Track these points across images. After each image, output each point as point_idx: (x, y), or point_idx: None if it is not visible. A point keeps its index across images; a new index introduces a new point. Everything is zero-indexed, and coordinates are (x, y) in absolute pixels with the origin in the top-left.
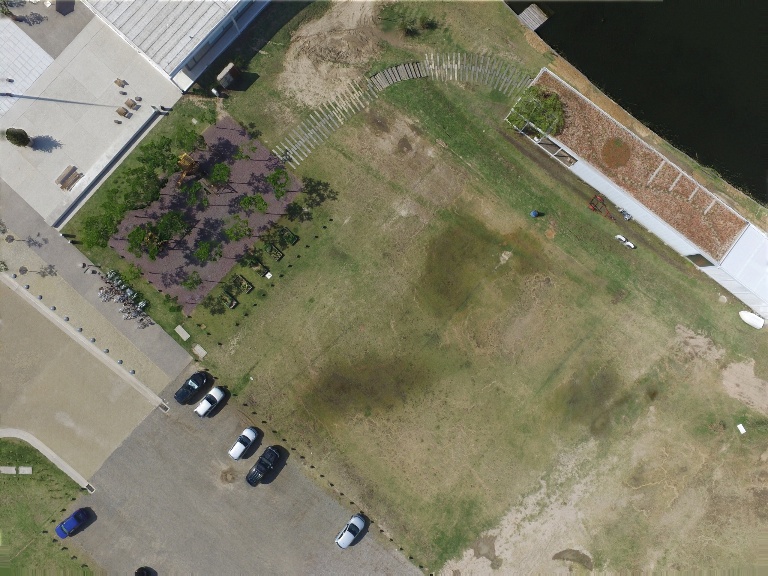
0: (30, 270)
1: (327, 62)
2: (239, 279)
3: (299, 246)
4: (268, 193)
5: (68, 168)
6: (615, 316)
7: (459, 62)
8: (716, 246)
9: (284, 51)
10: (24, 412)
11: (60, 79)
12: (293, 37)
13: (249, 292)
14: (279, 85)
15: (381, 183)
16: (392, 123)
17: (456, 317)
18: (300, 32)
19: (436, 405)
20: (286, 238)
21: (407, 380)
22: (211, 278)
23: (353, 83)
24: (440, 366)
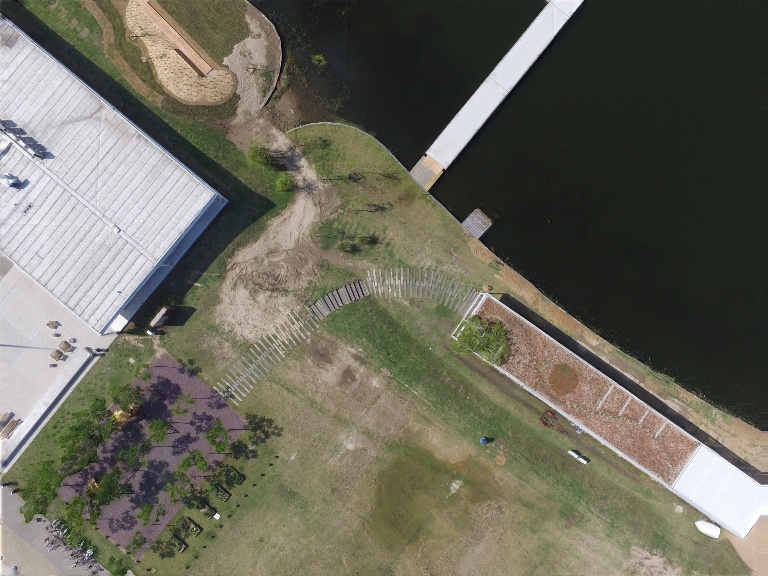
0: None
1: (265, 291)
2: (187, 522)
3: (246, 485)
4: None
5: (5, 416)
6: (569, 540)
7: (402, 277)
8: (668, 470)
9: (220, 282)
10: None
11: None
12: (229, 265)
13: (198, 534)
14: (217, 318)
15: (326, 417)
16: (335, 353)
17: (408, 550)
18: (236, 259)
19: None
20: (232, 479)
21: None
22: (158, 521)
23: (293, 313)
24: None
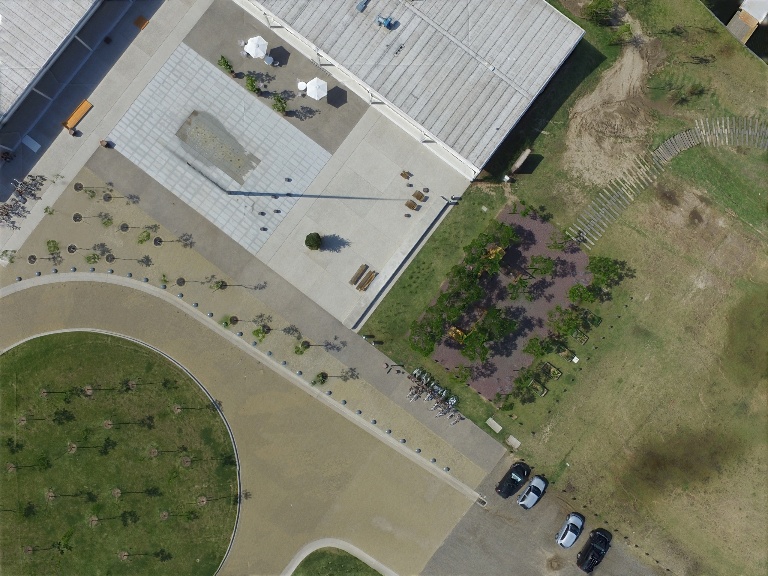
0: (330, 375)
1: (609, 138)
2: (547, 366)
3: (602, 327)
4: (566, 276)
5: (361, 267)
6: None
7: (728, 126)
8: None
9: (565, 130)
10: (339, 521)
11: (341, 175)
12: (571, 114)
13: (558, 378)
14: (565, 165)
15: (677, 257)
16: (681, 196)
17: (761, 384)
18: (576, 108)
19: (750, 473)
20: (590, 321)
21: (720, 451)
22: (517, 367)
23: (639, 158)
24: (750, 434)
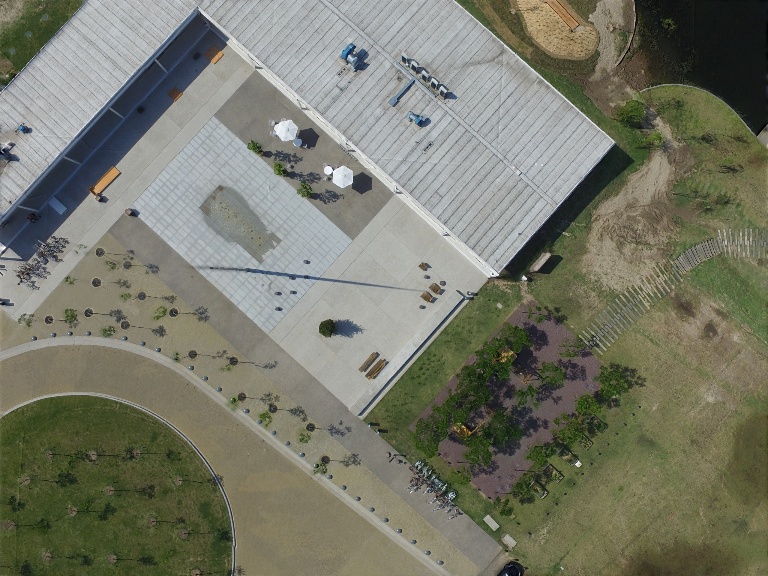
0: (332, 459)
1: (630, 244)
2: (549, 468)
3: (608, 434)
4: (576, 380)
5: (372, 355)
6: None
7: (751, 238)
8: None
9: (587, 232)
10: None
11: (359, 261)
12: (593, 216)
13: (559, 481)
14: (583, 268)
15: (688, 369)
16: (698, 308)
17: (763, 503)
18: (600, 211)
19: None
20: (596, 427)
21: (716, 567)
22: (520, 467)
23: (658, 266)
24: (748, 553)
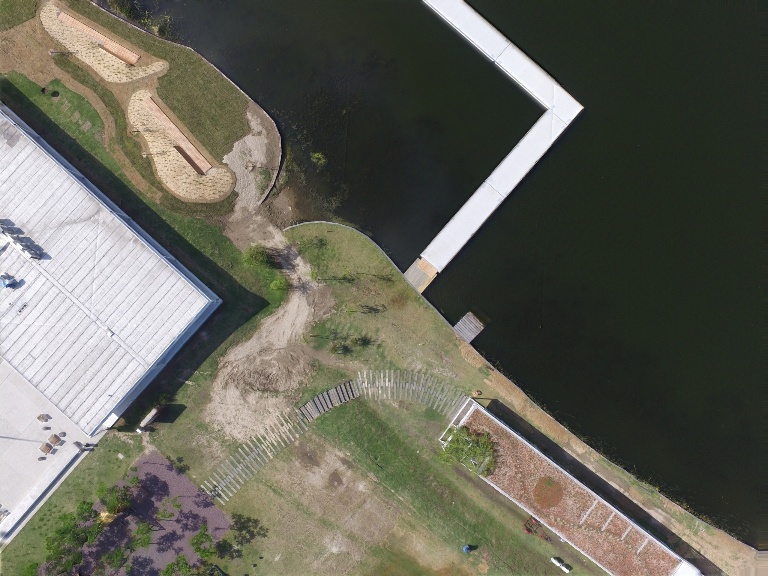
0: None
1: (256, 392)
2: None
3: None
4: (197, 530)
5: None
6: None
7: (393, 379)
8: None
9: (211, 380)
10: None
11: None
12: (221, 363)
13: None
14: (207, 417)
15: (312, 519)
16: (322, 457)
17: None
18: (228, 357)
19: None
20: None
21: None
22: None
23: (282, 415)
24: None
